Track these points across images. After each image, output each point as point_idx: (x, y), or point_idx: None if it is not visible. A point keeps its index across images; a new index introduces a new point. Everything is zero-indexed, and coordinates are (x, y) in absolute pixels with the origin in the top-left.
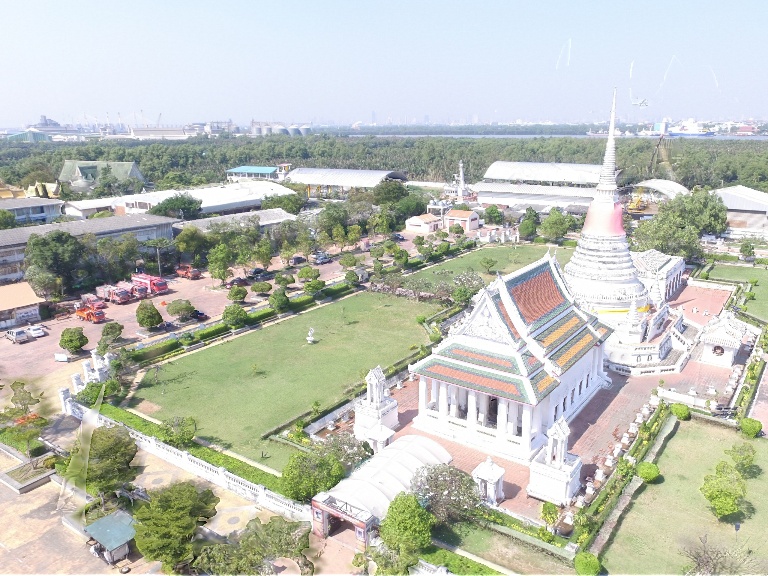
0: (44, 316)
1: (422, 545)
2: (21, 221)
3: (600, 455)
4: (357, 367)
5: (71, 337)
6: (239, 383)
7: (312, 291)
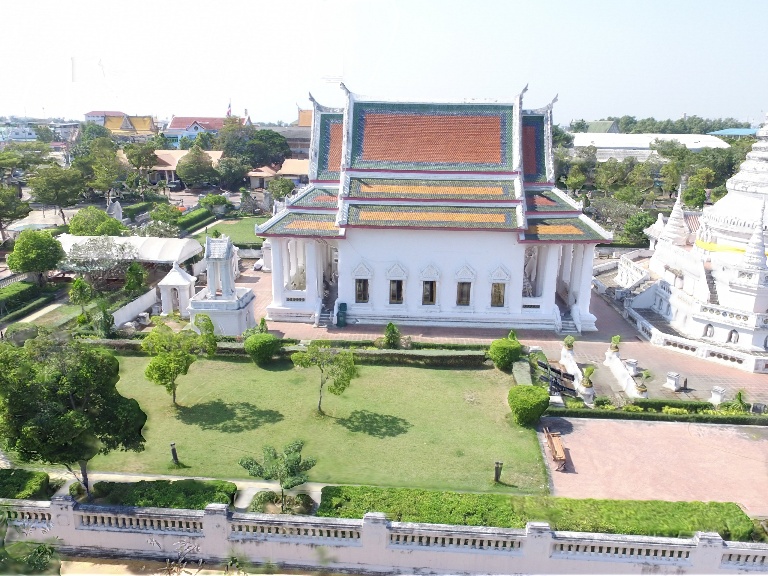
0: None
1: None
2: None
3: None
4: None
5: None
6: None
7: None
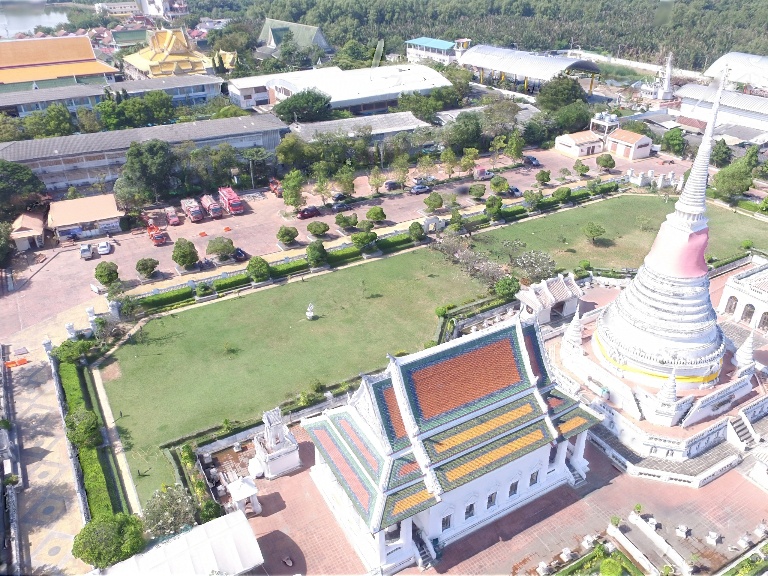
0: (124, 228)
1: None
2: (183, 100)
3: None
4: (324, 368)
5: (101, 272)
6: (205, 360)
7: (358, 244)
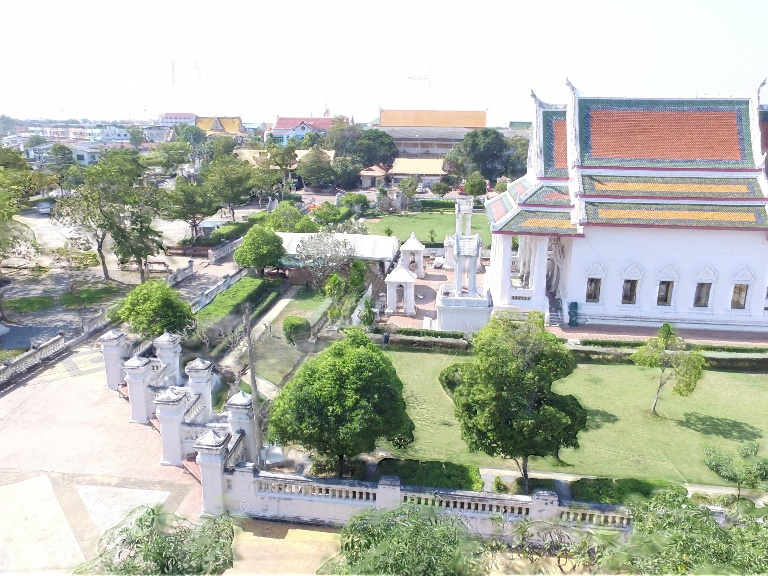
0: None
1: (243, 263)
2: None
3: None
4: None
5: None
6: (447, 227)
7: None
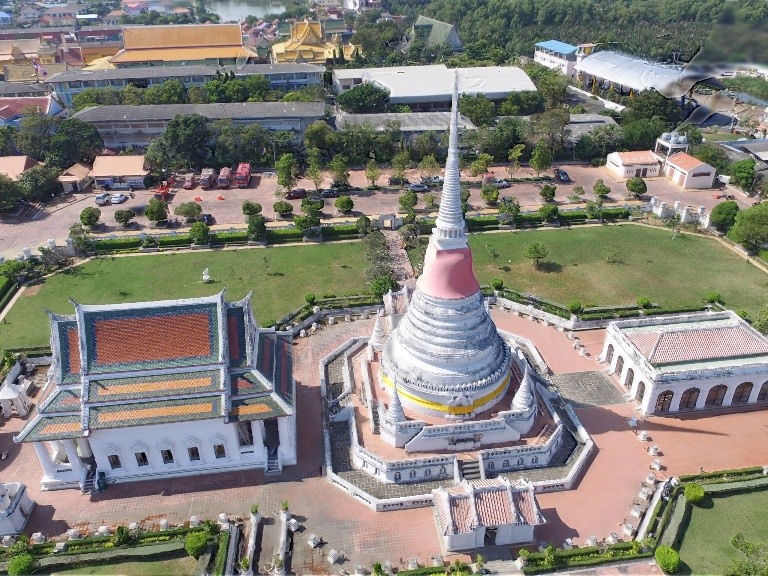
0: (147, 185)
1: None
2: (285, 85)
3: (92, 524)
4: None
5: (84, 215)
6: (99, 297)
7: (297, 227)
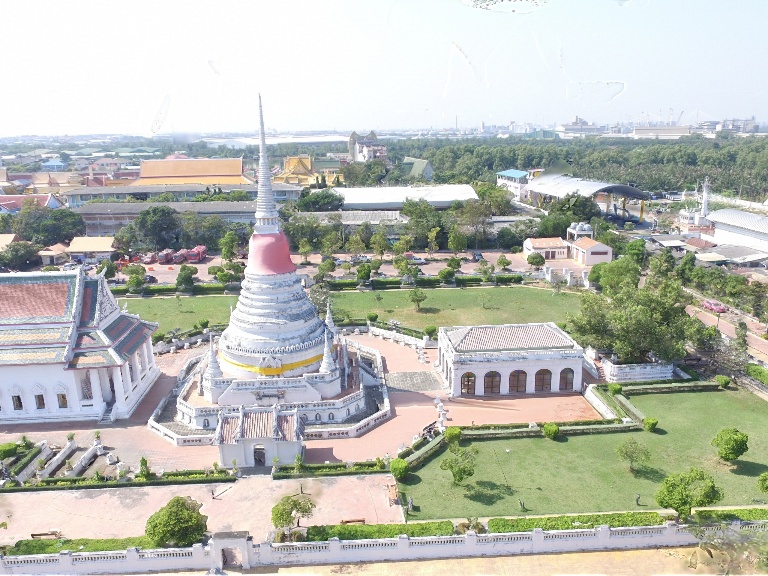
0: (113, 261)
1: None
2: None
3: None
4: None
5: None
6: None
7: (219, 281)
